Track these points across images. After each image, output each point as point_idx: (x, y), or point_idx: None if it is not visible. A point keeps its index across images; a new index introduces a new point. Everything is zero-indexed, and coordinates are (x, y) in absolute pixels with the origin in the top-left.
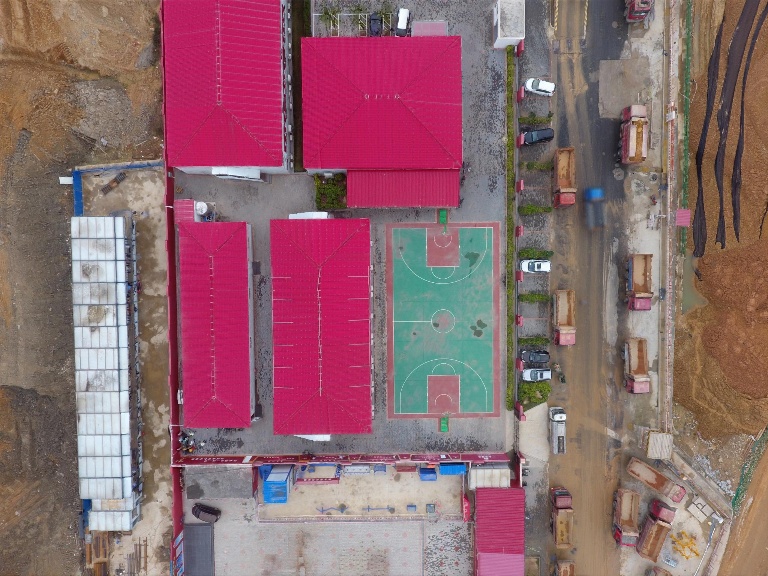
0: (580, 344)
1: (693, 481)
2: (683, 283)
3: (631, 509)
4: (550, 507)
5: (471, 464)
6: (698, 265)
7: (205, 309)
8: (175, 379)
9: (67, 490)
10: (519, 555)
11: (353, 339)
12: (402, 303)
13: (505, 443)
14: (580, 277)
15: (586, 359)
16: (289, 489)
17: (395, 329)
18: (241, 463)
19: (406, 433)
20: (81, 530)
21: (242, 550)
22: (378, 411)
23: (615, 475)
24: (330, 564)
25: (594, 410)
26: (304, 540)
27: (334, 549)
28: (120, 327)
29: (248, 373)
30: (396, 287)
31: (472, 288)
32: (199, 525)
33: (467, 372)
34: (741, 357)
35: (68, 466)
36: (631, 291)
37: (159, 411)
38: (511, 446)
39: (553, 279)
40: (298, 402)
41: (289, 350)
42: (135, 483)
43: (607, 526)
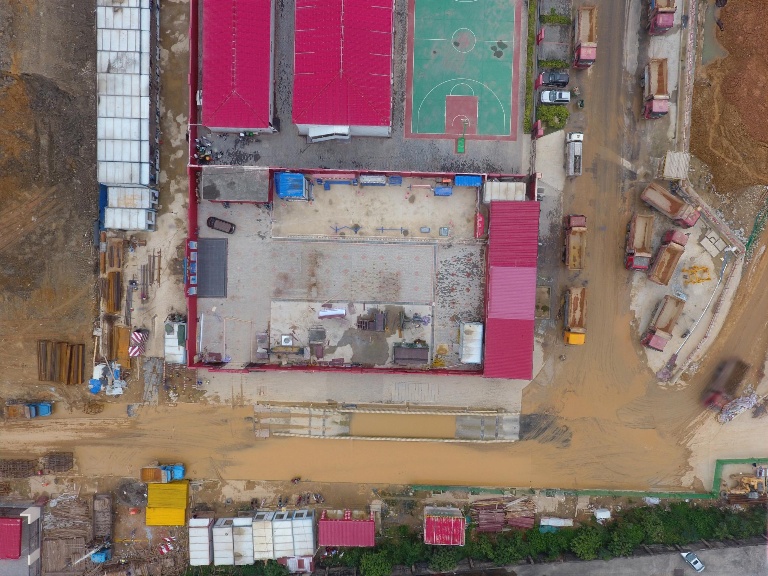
0: (600, 71)
1: (707, 215)
2: (704, 33)
3: (644, 237)
4: (563, 235)
5: (487, 177)
6: (720, 15)
7: (228, 1)
8: (195, 83)
9: (83, 197)
10: (531, 268)
11: (375, 26)
12: (423, 20)
13: (521, 168)
14: (603, 2)
15: (605, 87)
16: (305, 194)
17: (415, 46)
18: (258, 166)
19: (422, 153)
20: (96, 236)
21: (255, 267)
22: (395, 130)
23: (629, 208)
24: (342, 285)
25: (611, 140)
26: (317, 259)
27: (346, 270)
28: (143, 9)
29: (268, 72)
30: (418, 3)
31: (494, 7)
32: (213, 239)
33: (486, 93)
34: (760, 100)
35: (85, 173)
36: (654, 9)
37: (177, 121)
38: (527, 171)
39: (575, 3)
40: (318, 87)
41: (311, 35)
42: (152, 175)
43: (619, 259)
